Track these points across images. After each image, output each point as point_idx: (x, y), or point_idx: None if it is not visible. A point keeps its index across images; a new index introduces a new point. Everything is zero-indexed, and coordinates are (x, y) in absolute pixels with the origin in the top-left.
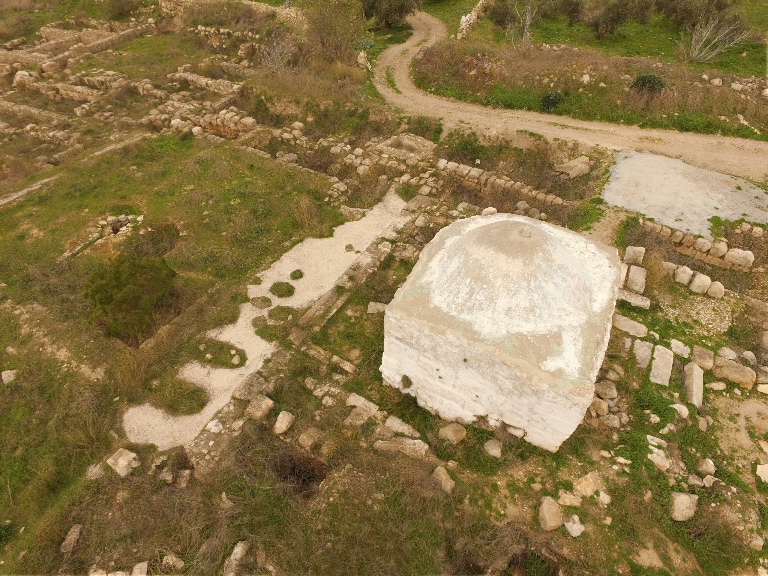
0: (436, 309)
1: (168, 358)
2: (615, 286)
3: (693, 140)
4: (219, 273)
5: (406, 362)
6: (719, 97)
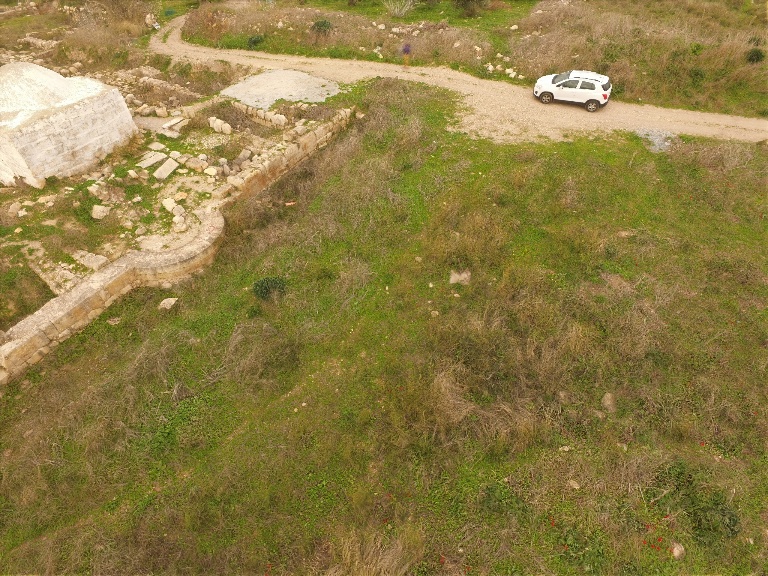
0: None
1: None
2: (87, 100)
3: (334, 63)
4: None
5: None
6: (370, 35)
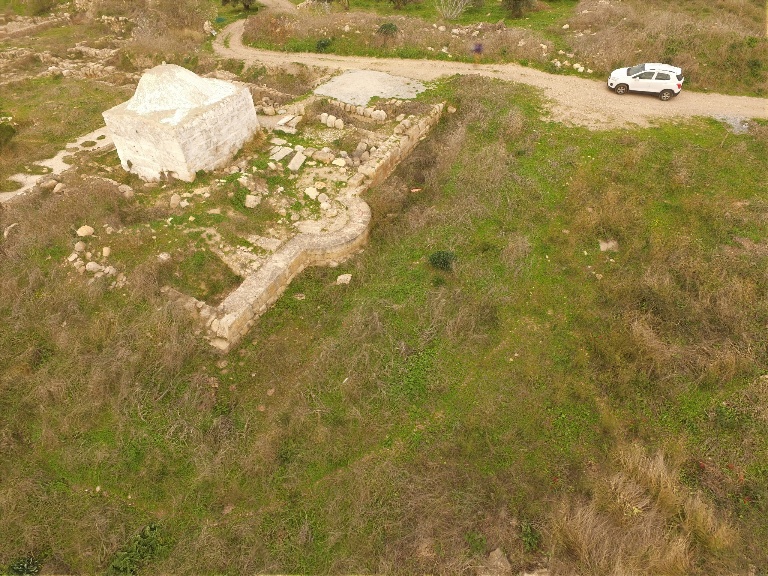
0: (126, 110)
1: (3, 170)
2: (228, 98)
3: (407, 63)
4: (52, 139)
5: (125, 149)
6: (435, 36)
